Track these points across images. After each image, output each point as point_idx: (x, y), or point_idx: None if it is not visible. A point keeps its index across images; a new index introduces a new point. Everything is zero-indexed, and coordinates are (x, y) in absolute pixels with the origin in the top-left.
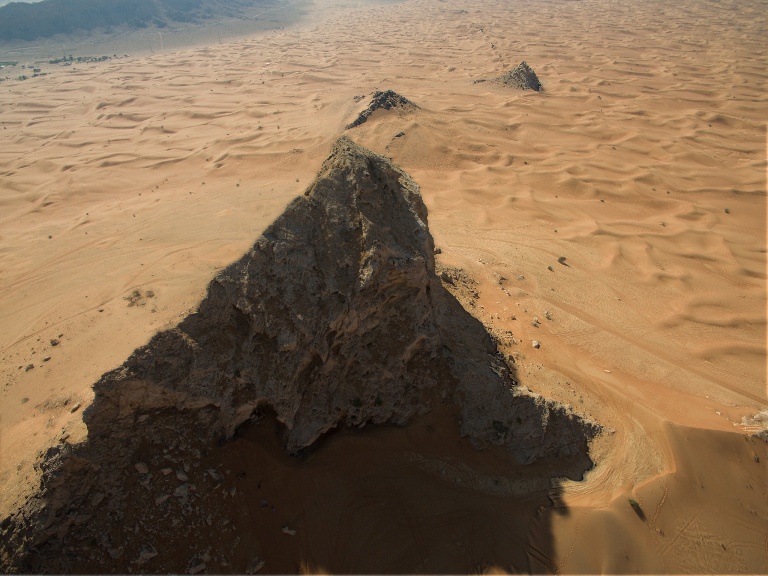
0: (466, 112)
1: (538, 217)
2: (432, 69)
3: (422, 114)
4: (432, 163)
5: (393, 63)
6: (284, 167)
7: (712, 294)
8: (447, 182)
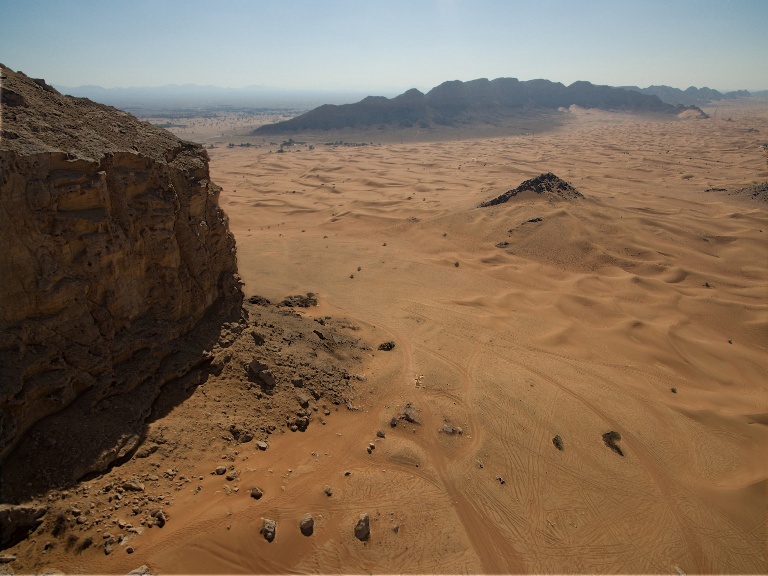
0: (660, 214)
1: (662, 360)
2: (661, 175)
3: (582, 204)
4: (559, 258)
5: (615, 165)
6: (389, 232)
7: None
8: (557, 282)
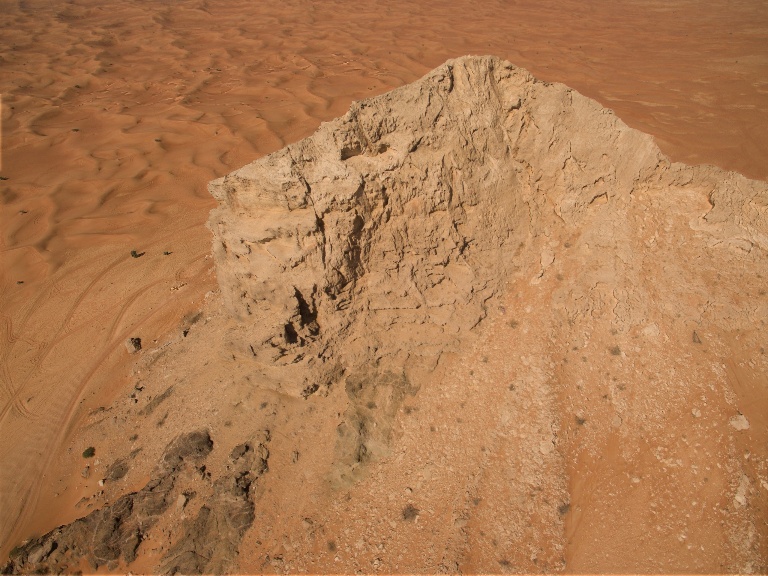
0: None
1: None
2: None
3: None
4: None
5: None
6: None
7: (177, 192)
8: None
